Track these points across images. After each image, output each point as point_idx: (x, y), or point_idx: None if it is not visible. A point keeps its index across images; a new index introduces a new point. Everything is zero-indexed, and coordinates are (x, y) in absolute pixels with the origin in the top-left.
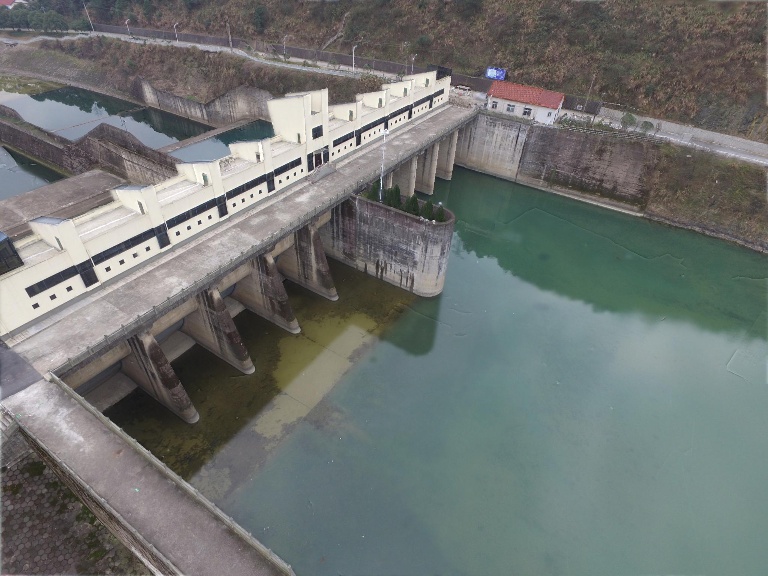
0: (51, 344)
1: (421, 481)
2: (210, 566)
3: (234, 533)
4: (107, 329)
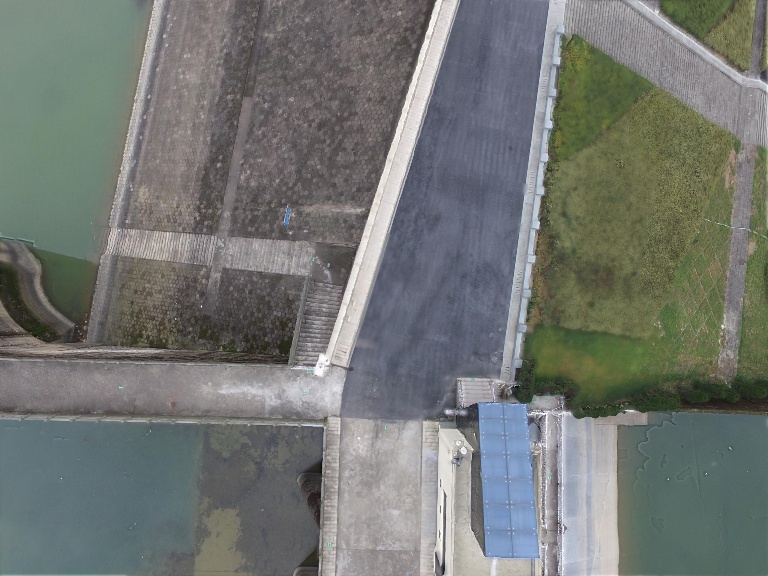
0: (388, 454)
1: (40, 563)
2: (3, 378)
3: (4, 410)
4: (354, 514)
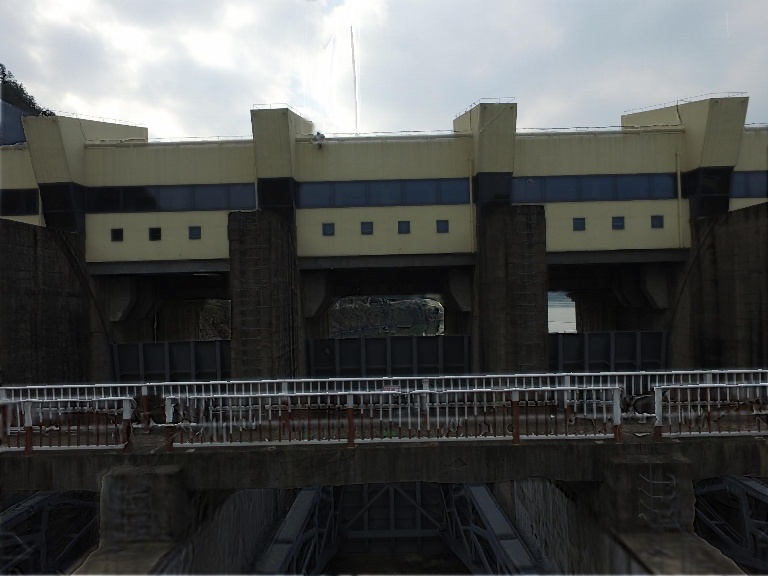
0: None
1: None
2: None
3: None
4: None
